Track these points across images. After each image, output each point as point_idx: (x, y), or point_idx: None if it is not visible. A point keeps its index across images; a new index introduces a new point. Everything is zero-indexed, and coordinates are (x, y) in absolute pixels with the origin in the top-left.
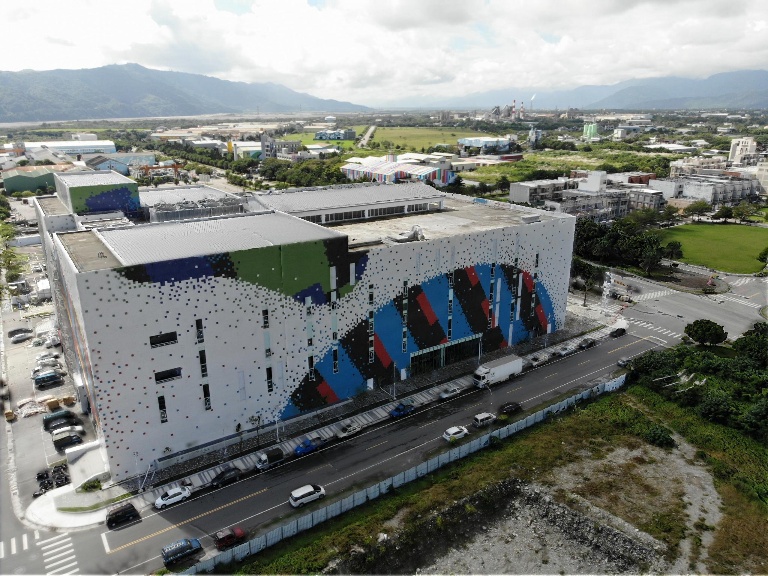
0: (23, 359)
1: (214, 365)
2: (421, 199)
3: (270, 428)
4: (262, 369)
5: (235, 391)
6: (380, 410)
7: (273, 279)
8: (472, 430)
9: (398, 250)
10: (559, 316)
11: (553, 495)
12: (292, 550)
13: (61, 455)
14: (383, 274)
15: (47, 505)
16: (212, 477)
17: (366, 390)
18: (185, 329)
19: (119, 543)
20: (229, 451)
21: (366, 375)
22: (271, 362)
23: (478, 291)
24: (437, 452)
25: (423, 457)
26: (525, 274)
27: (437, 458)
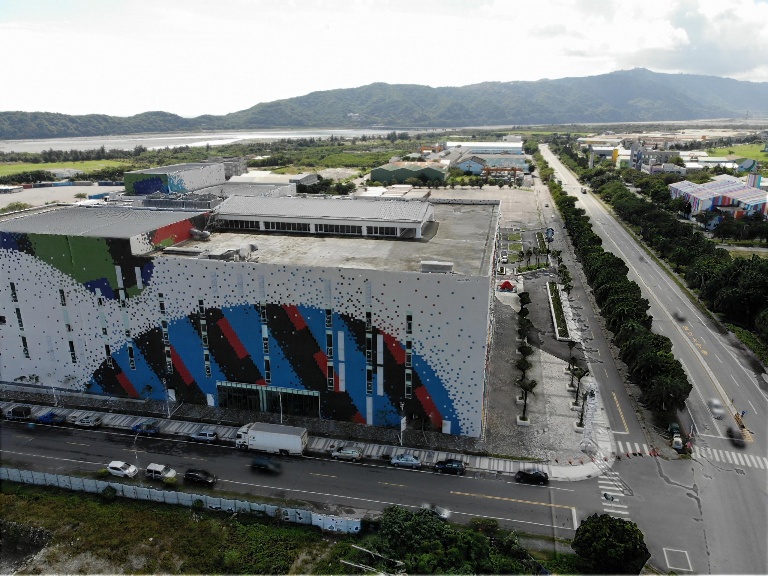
0: None
1: (29, 323)
2: (383, 221)
3: (70, 394)
4: (66, 340)
5: (46, 351)
6: (144, 420)
7: (65, 264)
8: (140, 476)
9: (188, 264)
10: (467, 416)
11: (24, 569)
12: None
13: None
14: (173, 286)
15: None
16: None
17: (168, 399)
18: (4, 287)
19: None
20: (29, 396)
21: (167, 384)
22: (73, 337)
23: (307, 338)
24: (82, 474)
25: (70, 472)
26: (388, 337)
27: (43, 474)
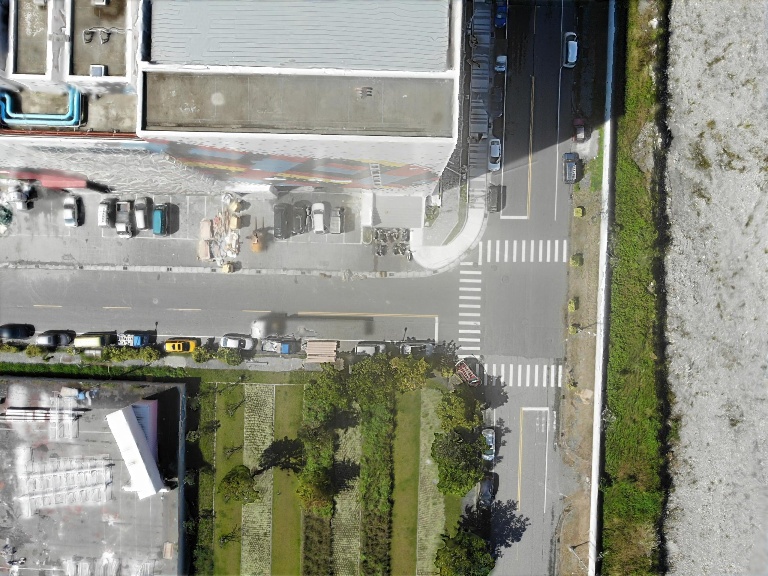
0: (49, 242)
1: None
2: None
3: None
4: None
5: None
6: None
7: None
8: None
9: None
10: None
11: None
12: (623, 94)
13: (353, 231)
14: None
15: (432, 252)
16: (483, 114)
17: None
18: None
19: (523, 208)
20: None
21: None
22: None
23: None
24: None
25: None
26: None
27: None
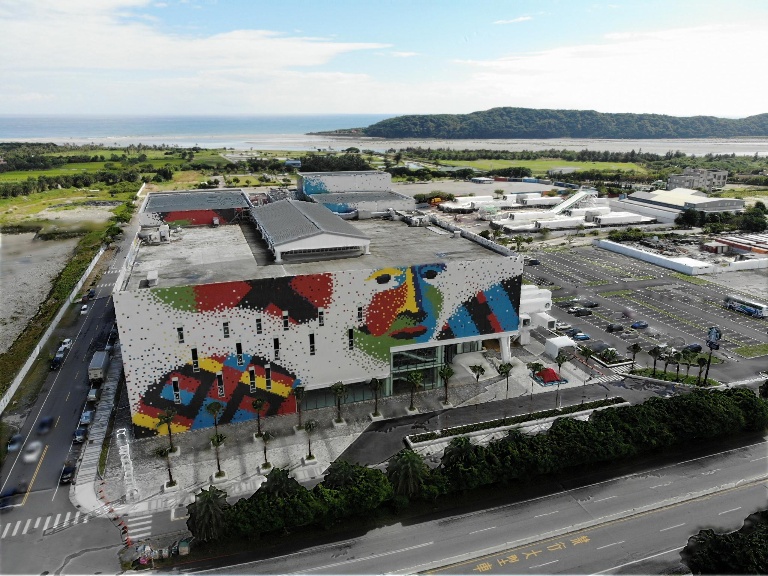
0: None
1: None
2: None
3: None
4: None
5: None
6: None
7: None
8: None
9: None
10: None
11: None
12: (59, 307)
13: None
14: None
15: None
16: None
17: None
18: None
19: None
20: None
21: None
22: None
23: None
24: (64, 339)
25: (68, 336)
26: None
27: None
